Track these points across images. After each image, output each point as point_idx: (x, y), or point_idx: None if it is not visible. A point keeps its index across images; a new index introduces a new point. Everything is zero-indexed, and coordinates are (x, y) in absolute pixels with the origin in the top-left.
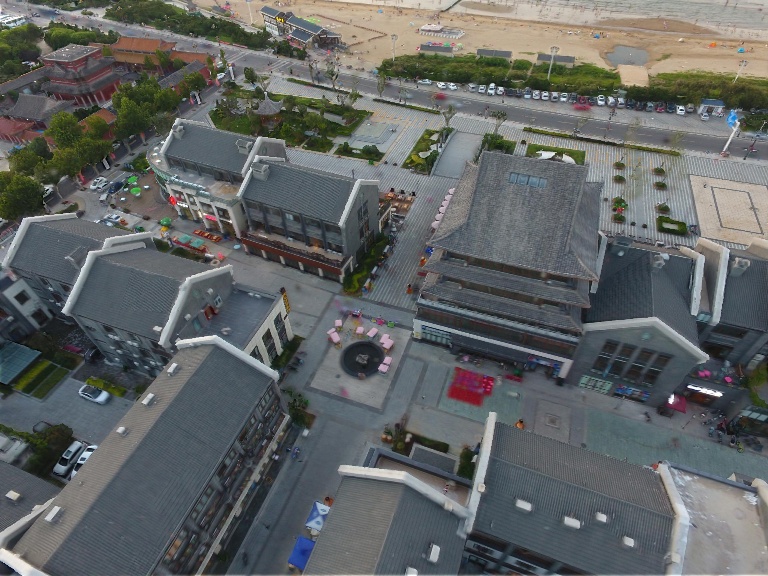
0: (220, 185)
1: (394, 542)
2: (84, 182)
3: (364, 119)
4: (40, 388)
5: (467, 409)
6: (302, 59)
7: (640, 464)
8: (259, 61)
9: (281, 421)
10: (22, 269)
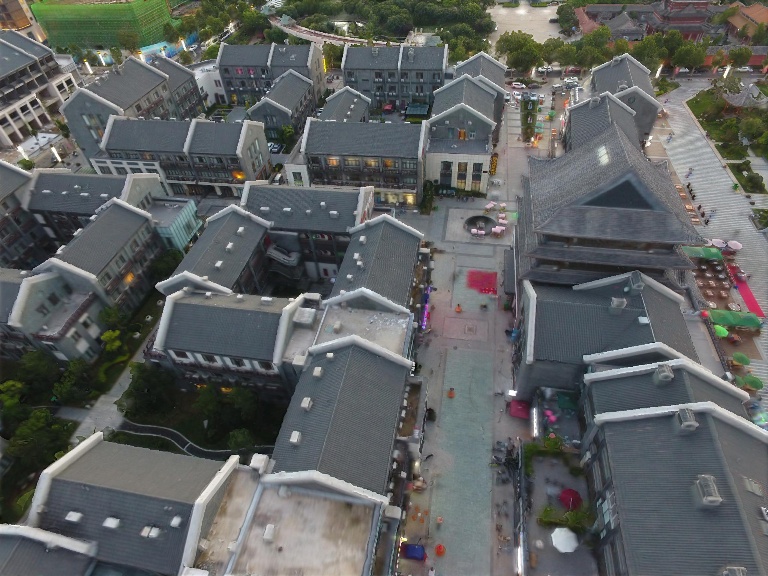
0: None
1: (334, 195)
2: (570, 76)
3: None
4: None
5: (462, 281)
6: None
7: (451, 383)
8: None
9: (410, 188)
10: None
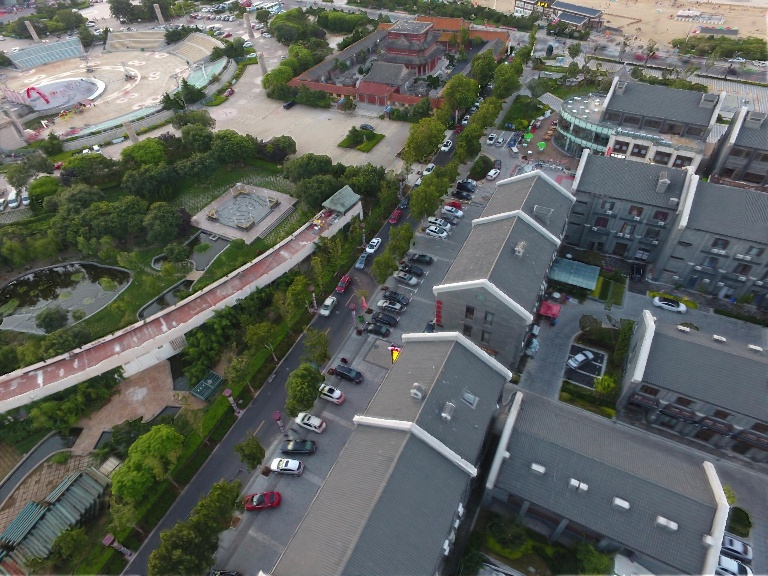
0: (669, 137)
1: None
2: None
3: (707, 91)
4: (613, 297)
5: None
6: (584, 40)
7: None
8: (538, 42)
9: None
10: (592, 192)
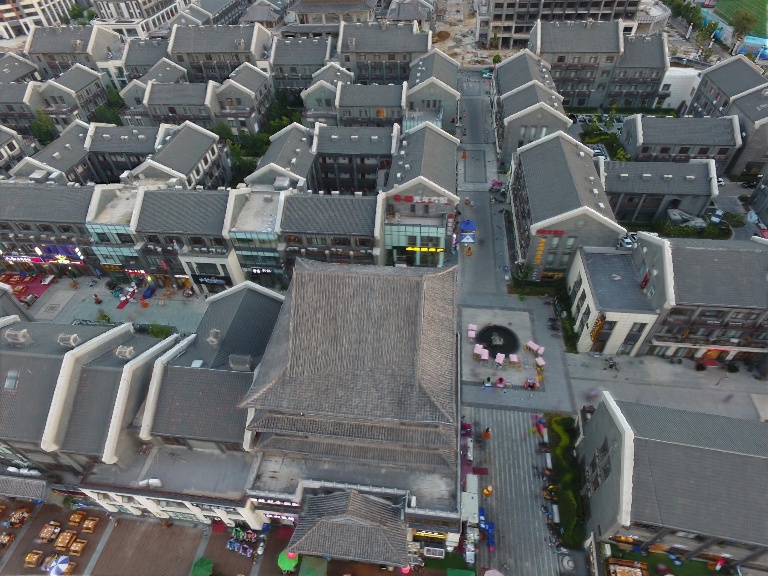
0: None
1: None
2: None
3: None
4: None
5: None
6: None
7: None
8: None
9: None
10: None
